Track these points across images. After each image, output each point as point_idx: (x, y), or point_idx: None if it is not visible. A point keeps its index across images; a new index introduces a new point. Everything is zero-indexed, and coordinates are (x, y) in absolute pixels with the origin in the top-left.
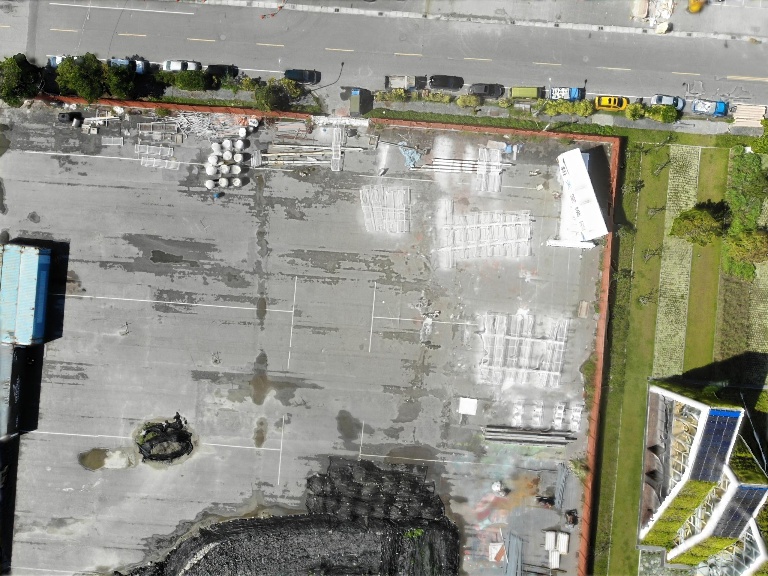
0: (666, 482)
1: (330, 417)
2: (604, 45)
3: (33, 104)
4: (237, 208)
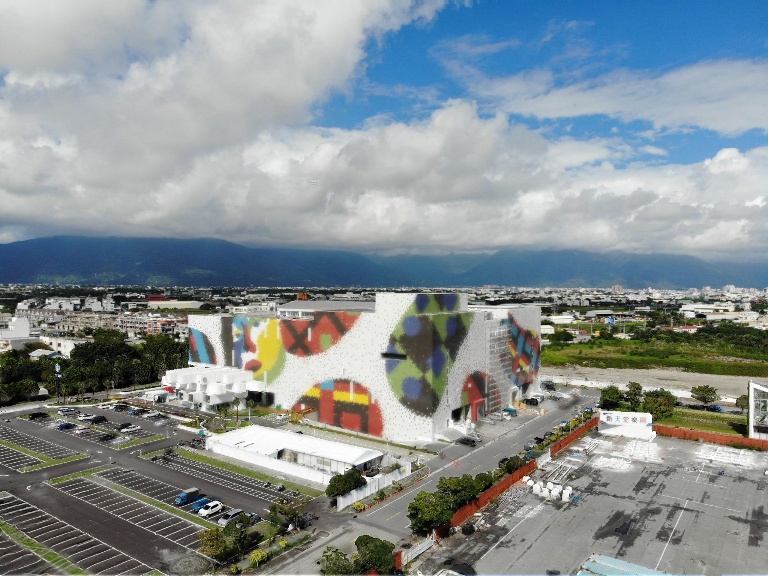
0: None
1: None
2: (542, 420)
3: (440, 544)
4: (590, 498)
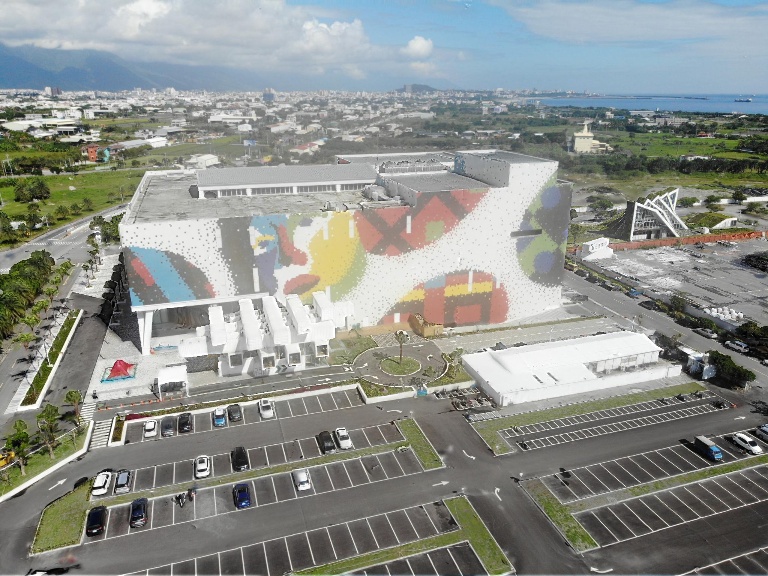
0: (658, 229)
1: (766, 279)
2: None
3: None
4: None
